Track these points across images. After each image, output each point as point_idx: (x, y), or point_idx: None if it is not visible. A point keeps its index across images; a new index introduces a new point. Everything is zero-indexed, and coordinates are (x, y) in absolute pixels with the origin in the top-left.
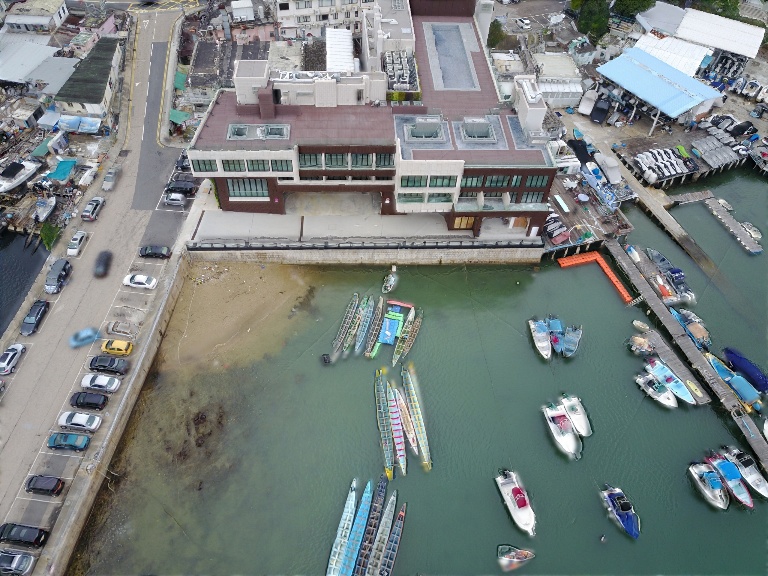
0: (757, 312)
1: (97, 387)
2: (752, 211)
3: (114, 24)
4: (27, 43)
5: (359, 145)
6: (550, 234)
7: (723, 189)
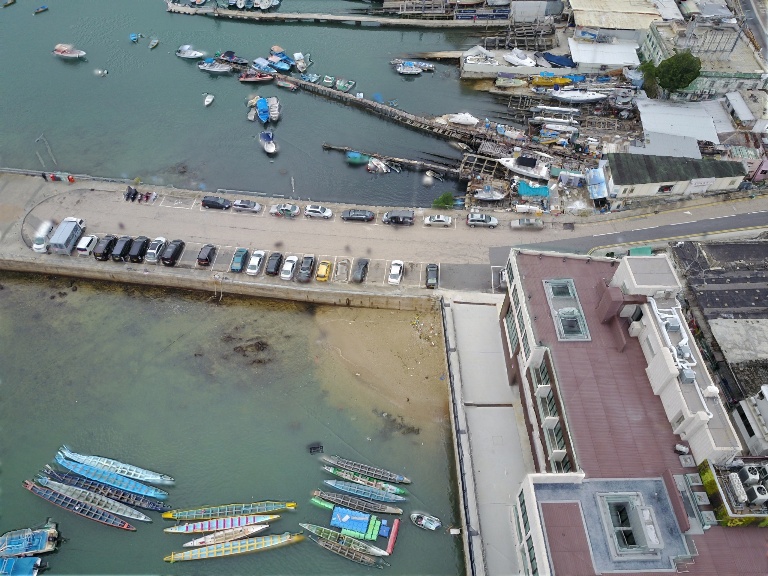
0: None
1: None
2: None
3: None
4: (709, 119)
5: (566, 423)
6: None
7: None
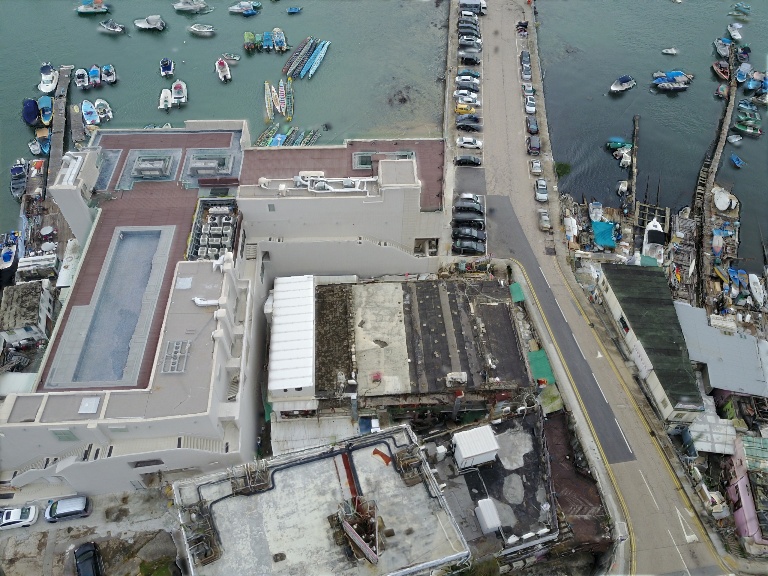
0: None
1: None
2: None
3: (753, 536)
4: None
5: None
6: None
7: None
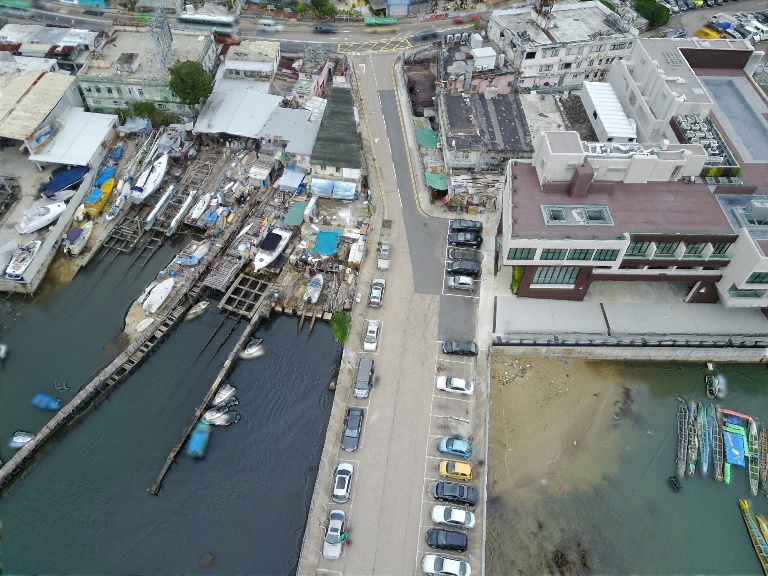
0: None
1: (453, 523)
2: None
3: (327, 68)
4: (249, 91)
5: (697, 234)
6: None
7: None
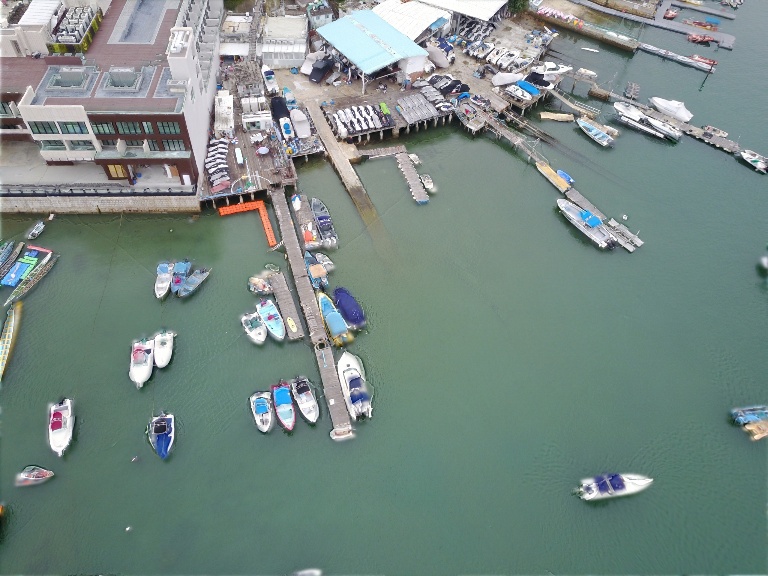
0: (399, 257)
1: None
2: (441, 165)
3: None
4: None
5: None
6: (211, 184)
7: (423, 145)
